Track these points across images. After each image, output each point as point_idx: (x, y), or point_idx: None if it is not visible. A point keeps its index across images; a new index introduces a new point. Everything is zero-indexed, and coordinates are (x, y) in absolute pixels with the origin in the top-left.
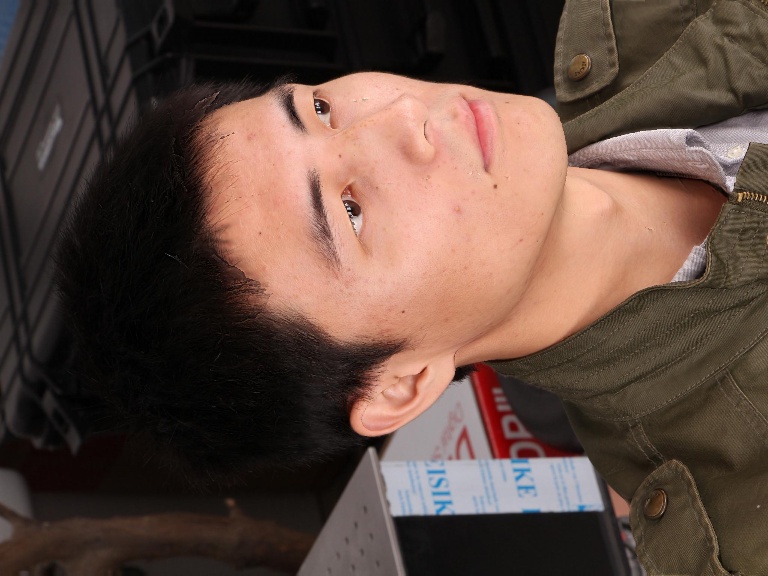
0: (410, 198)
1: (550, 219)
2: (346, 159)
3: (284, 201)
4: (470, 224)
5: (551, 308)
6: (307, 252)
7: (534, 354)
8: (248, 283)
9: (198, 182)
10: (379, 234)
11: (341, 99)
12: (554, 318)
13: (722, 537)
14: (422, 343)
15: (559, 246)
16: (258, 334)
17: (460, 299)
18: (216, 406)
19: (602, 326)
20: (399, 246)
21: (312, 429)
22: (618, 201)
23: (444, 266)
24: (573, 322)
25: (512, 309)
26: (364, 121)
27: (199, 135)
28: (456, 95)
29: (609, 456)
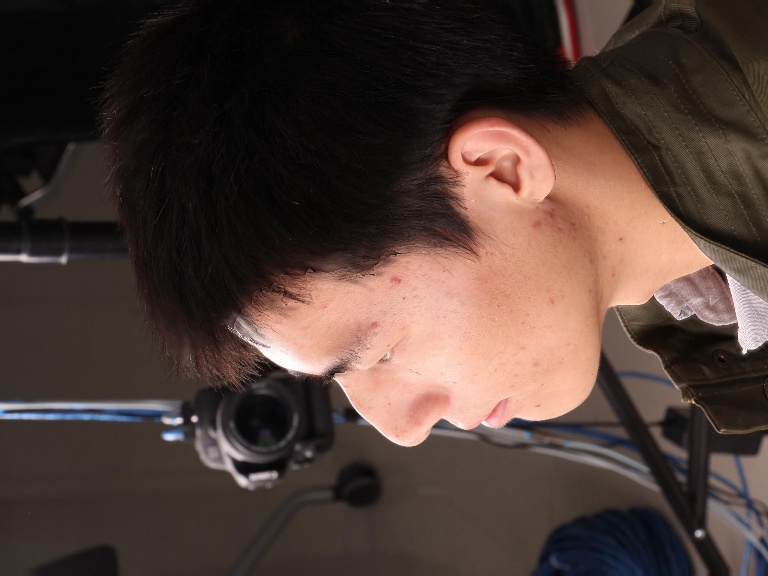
0: None
1: None
2: None
3: None
4: None
5: None
6: None
7: None
8: None
9: None
10: None
11: None
12: None
13: None
14: None
15: None
16: None
17: None
18: None
19: None
20: None
21: None
22: None
23: None
24: None
25: None
26: None
27: (254, 316)
28: None
29: None
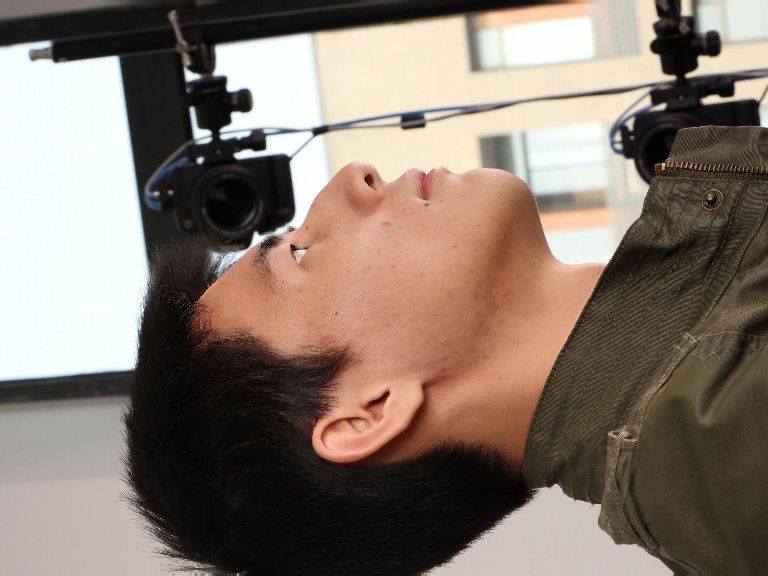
0: (349, 227)
1: (492, 235)
2: (312, 229)
3: None
4: (400, 234)
5: (534, 348)
6: (251, 279)
7: (536, 409)
8: (193, 306)
9: None
10: (316, 255)
11: None
12: (538, 357)
13: None
14: (370, 355)
15: (534, 289)
16: (207, 353)
17: (394, 299)
18: (174, 427)
19: (576, 345)
20: (328, 255)
21: (277, 456)
22: None
23: (369, 264)
24: None
25: (478, 337)
26: None
27: None
28: None
29: None
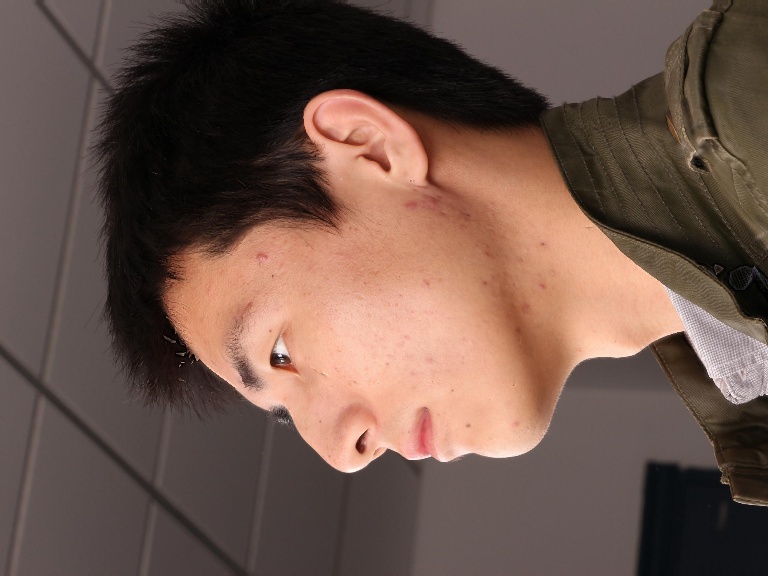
0: None
1: None
2: None
3: None
4: None
5: None
6: None
7: None
8: None
9: None
10: None
11: (301, 360)
12: None
13: None
14: None
15: None
16: None
17: None
18: None
19: None
20: None
21: None
22: (657, 327)
23: None
24: None
25: None
26: None
27: (171, 317)
28: (407, 428)
29: None
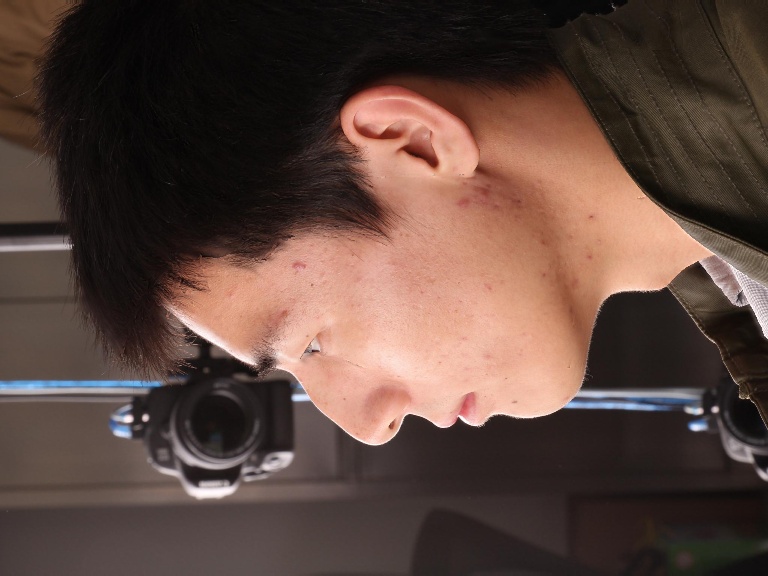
0: None
1: None
2: None
3: None
4: None
5: None
6: None
7: None
8: None
9: None
10: None
11: (335, 354)
12: None
13: None
14: None
15: None
16: None
17: None
18: None
19: None
20: None
21: None
22: None
23: None
24: None
25: None
26: None
27: None
28: (450, 410)
29: (685, 25)
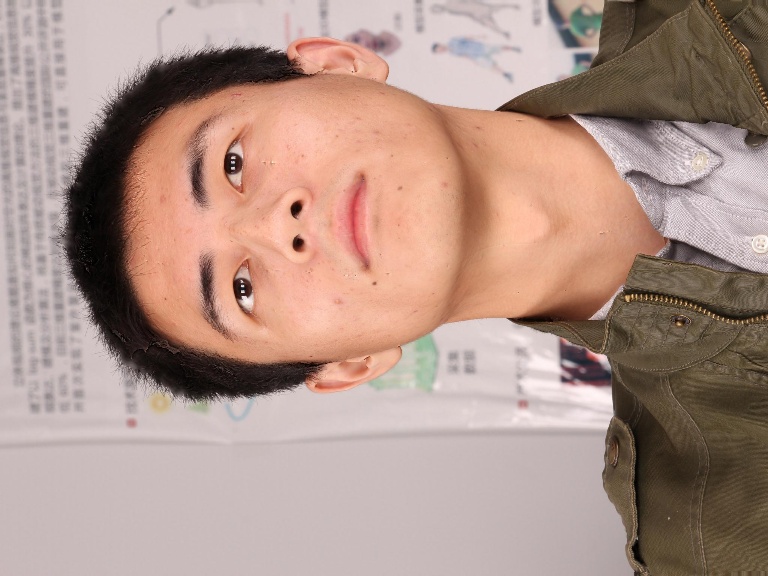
0: (294, 288)
1: (447, 290)
2: (238, 243)
3: (180, 281)
4: (355, 308)
5: (496, 304)
6: (206, 322)
7: None
8: None
9: (125, 226)
10: (269, 312)
11: (254, 155)
12: (502, 309)
13: (643, 525)
14: None
15: (487, 273)
16: None
17: (365, 347)
18: None
19: None
20: (287, 326)
21: None
22: (567, 210)
23: (335, 338)
24: (523, 311)
25: None
26: (240, 229)
27: None
28: (344, 187)
29: None
